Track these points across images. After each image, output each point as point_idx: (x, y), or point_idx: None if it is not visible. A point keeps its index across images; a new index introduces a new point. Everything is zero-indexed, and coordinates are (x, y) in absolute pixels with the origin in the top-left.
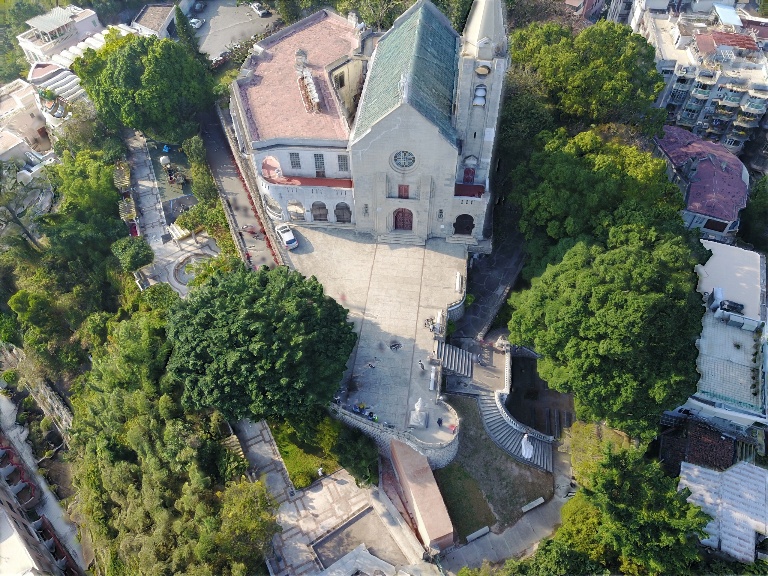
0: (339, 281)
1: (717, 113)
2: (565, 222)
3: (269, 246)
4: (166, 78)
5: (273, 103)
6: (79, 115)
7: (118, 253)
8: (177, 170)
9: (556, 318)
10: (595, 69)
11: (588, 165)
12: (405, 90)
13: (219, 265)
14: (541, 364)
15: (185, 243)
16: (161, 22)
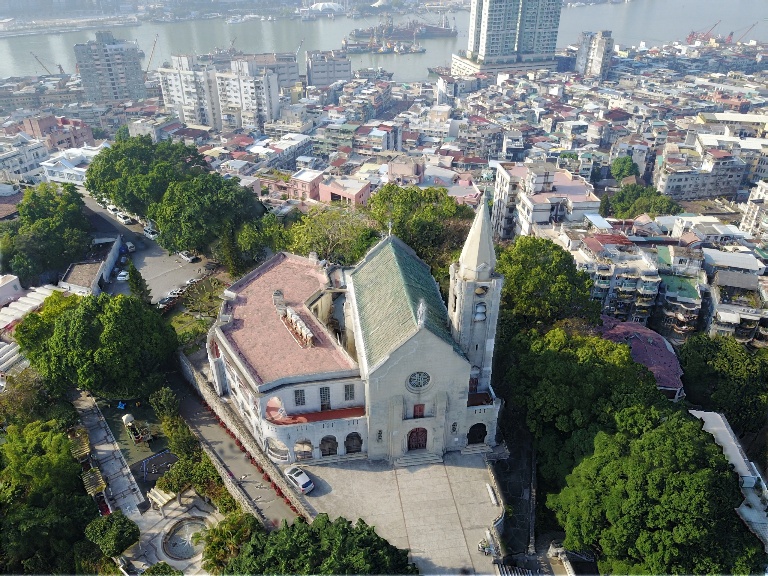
0: (370, 518)
1: (620, 298)
2: (573, 415)
3: (279, 494)
4: (127, 333)
5: (264, 344)
6: (23, 384)
7: (96, 537)
8: (139, 427)
9: (620, 513)
10: (538, 276)
11: (571, 359)
12: (423, 316)
13: (234, 527)
14: (604, 566)
15: (167, 508)
16: (92, 278)
